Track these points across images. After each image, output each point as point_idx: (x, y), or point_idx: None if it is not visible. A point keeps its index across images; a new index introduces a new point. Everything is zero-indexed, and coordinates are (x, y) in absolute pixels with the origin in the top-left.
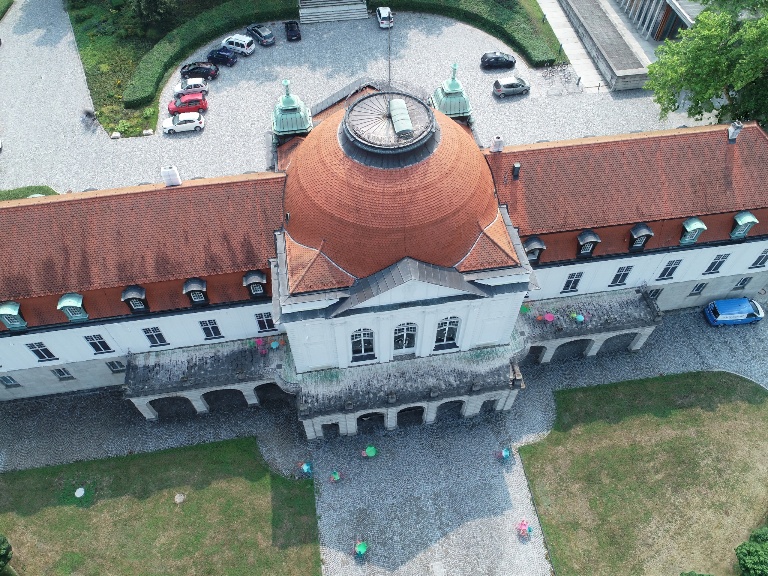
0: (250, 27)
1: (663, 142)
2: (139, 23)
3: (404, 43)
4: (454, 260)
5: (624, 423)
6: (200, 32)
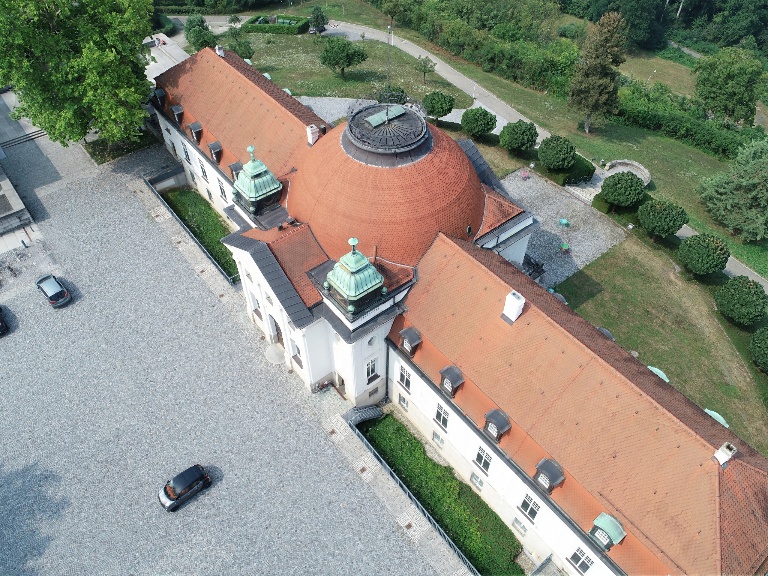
0: None
1: None
2: None
3: None
4: None
5: None
6: None
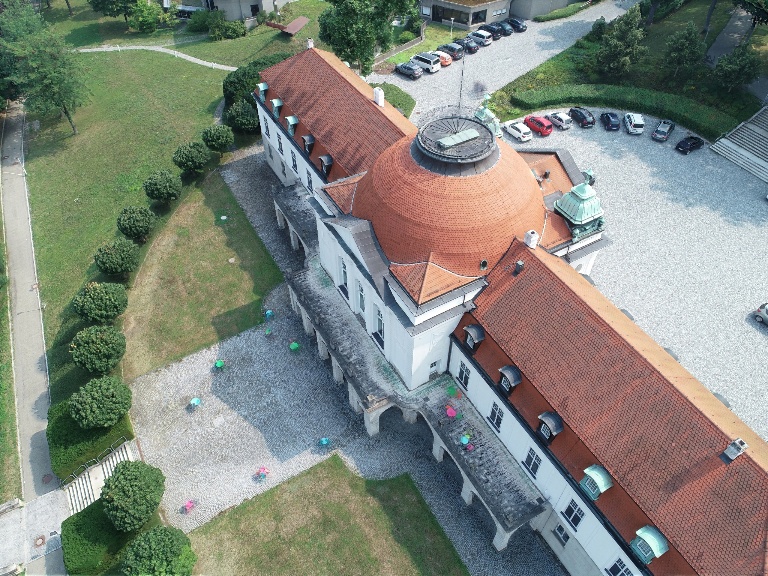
0: (663, 120)
1: (654, 378)
2: (598, 67)
3: (762, 221)
4: (394, 258)
5: (398, 547)
6: (624, 98)
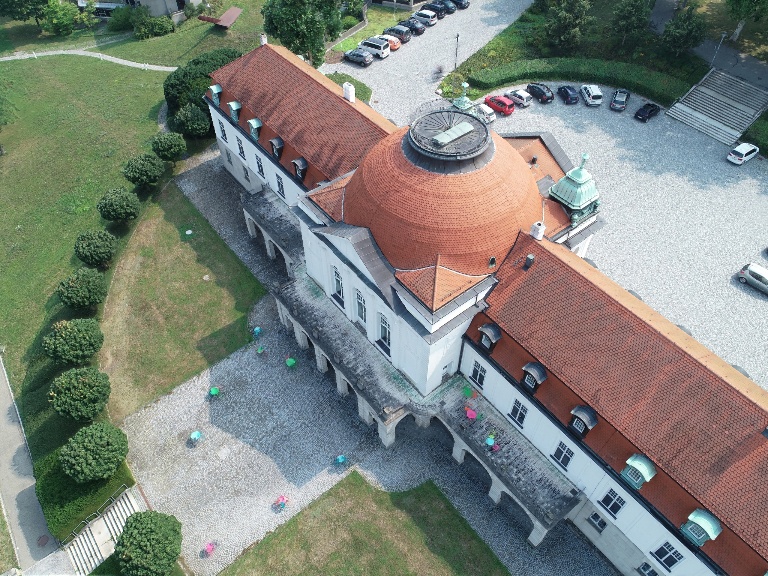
0: (618, 89)
1: (686, 361)
2: (547, 40)
3: (727, 182)
4: (399, 264)
5: (436, 558)
6: (578, 70)
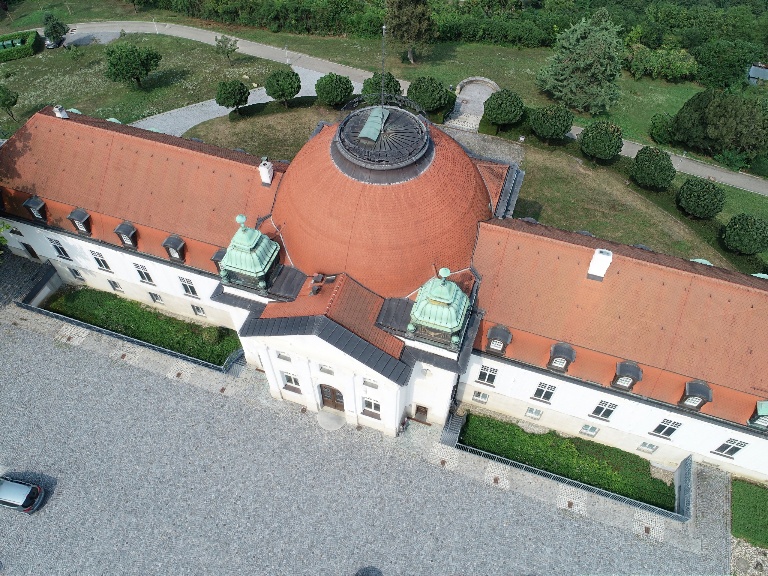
0: None
1: None
2: None
3: None
4: None
5: None
6: None
